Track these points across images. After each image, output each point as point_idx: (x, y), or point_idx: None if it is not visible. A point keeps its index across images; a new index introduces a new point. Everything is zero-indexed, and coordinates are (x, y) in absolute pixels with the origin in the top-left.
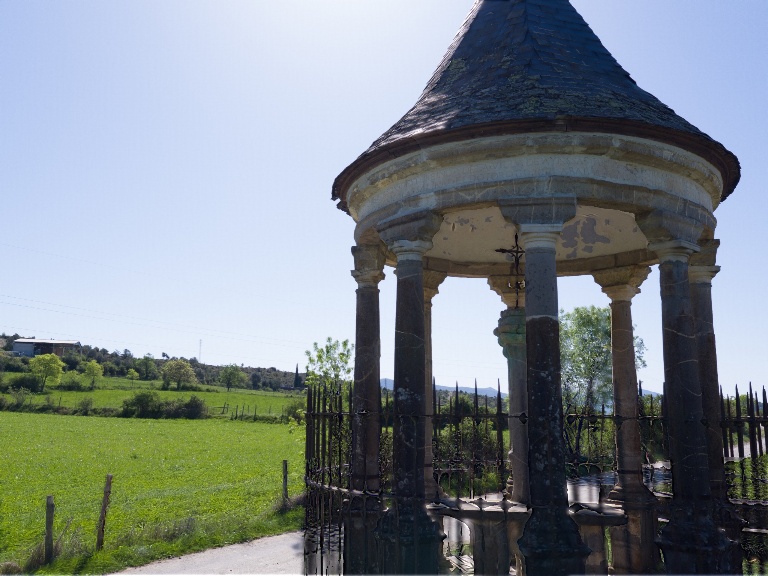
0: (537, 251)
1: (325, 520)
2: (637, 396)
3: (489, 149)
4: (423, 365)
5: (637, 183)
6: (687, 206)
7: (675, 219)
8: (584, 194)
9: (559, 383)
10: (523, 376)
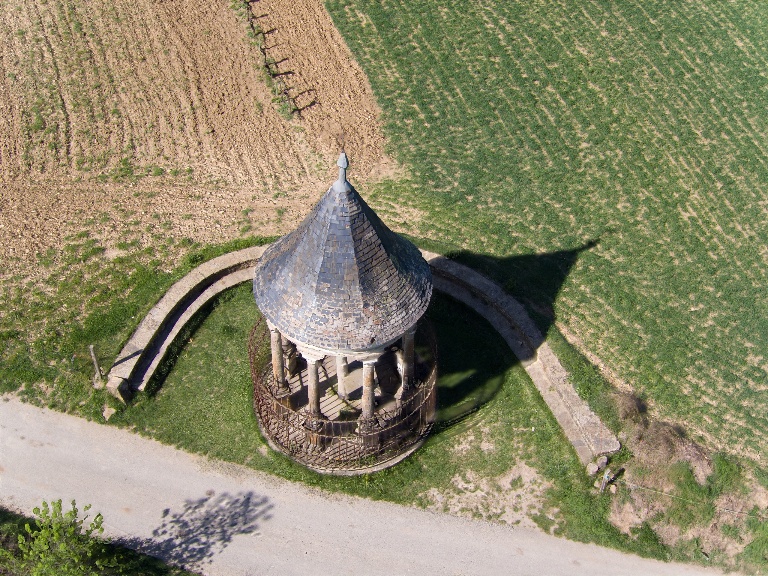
0: None
1: (167, 567)
2: None
3: None
4: None
5: None
6: None
7: None
8: None
9: None
10: None
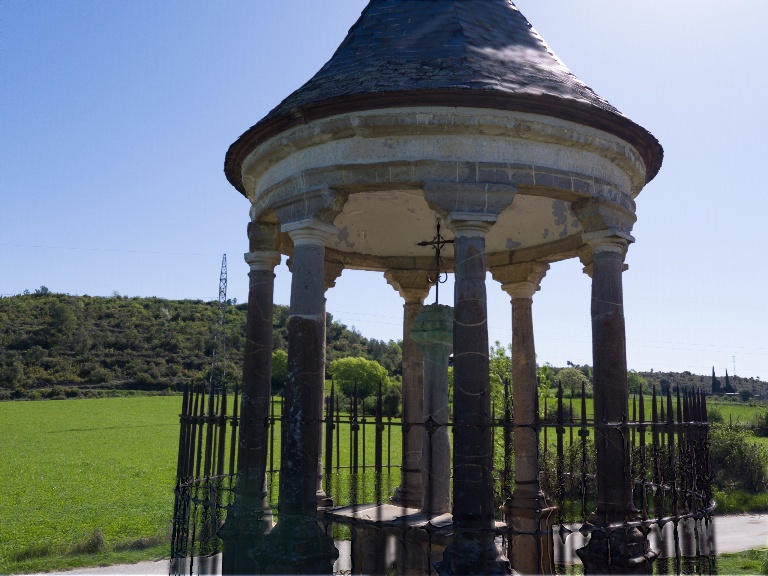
0: (295, 250)
1: None
2: None
3: (264, 156)
4: (261, 369)
5: (396, 158)
6: (478, 169)
7: (446, 189)
8: (335, 183)
9: (307, 384)
10: (431, 376)
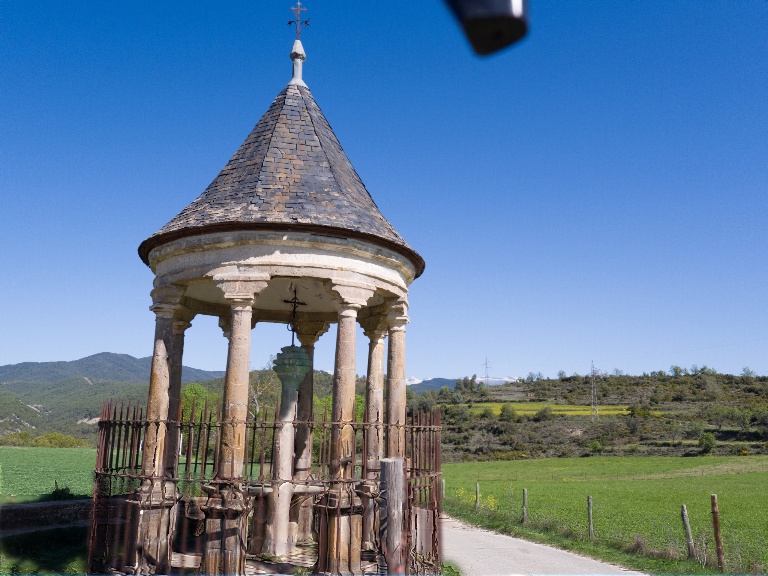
0: None
1: None
2: (225, 402)
3: None
4: None
5: None
6: None
7: None
8: None
9: None
10: None
